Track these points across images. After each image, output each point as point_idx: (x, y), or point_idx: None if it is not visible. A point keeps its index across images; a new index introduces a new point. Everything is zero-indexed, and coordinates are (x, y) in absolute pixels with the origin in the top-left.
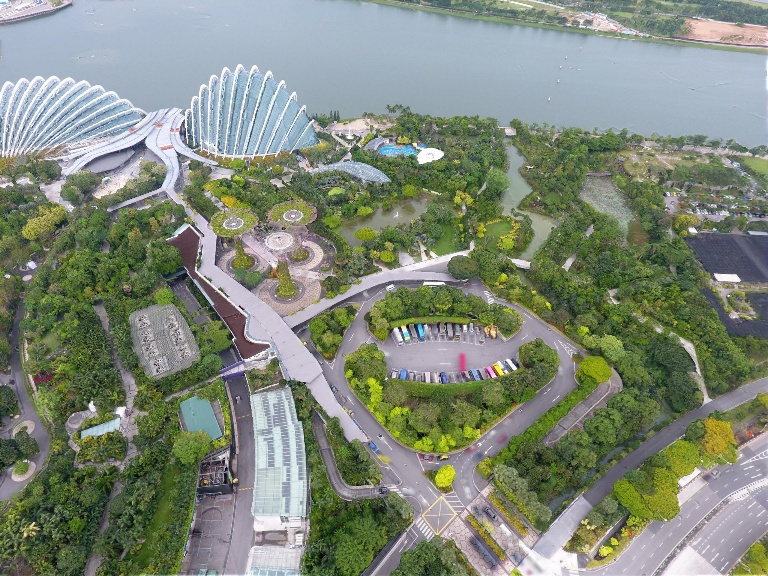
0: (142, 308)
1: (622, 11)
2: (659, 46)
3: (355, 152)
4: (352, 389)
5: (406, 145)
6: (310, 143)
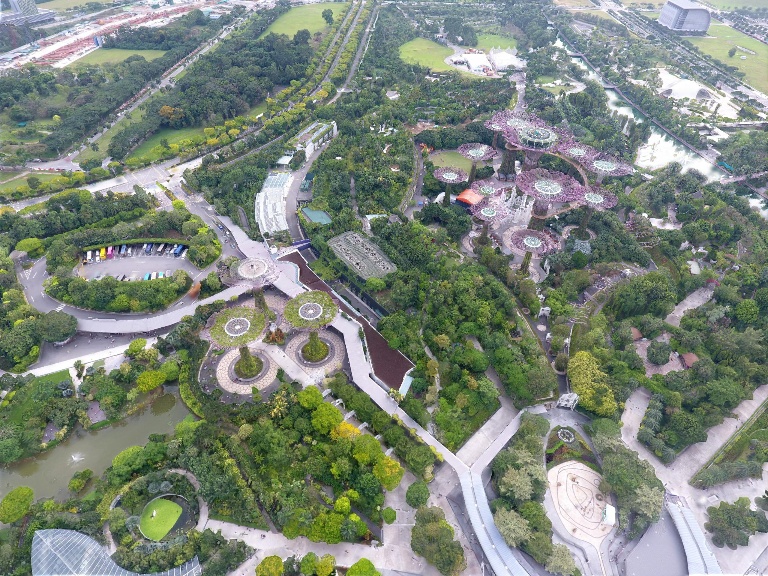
0: None
1: None
2: None
3: None
4: None
5: None
6: None
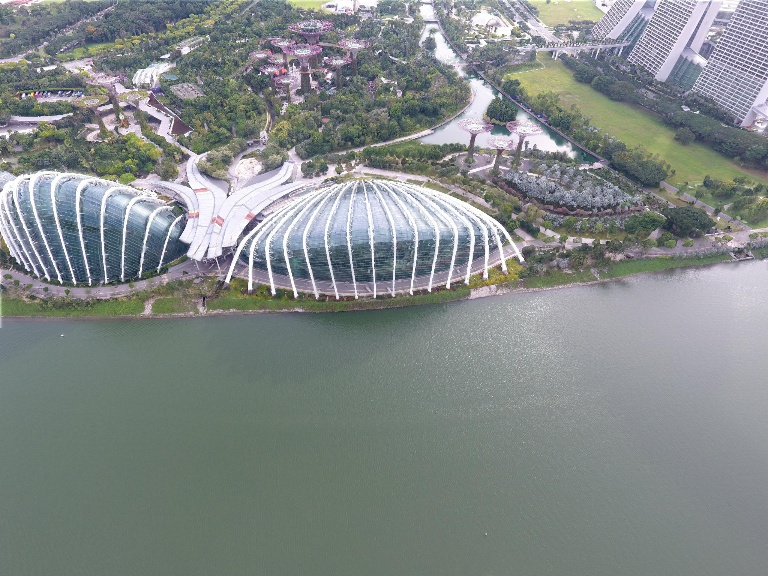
0: None
1: None
2: None
3: None
4: None
5: None
6: None
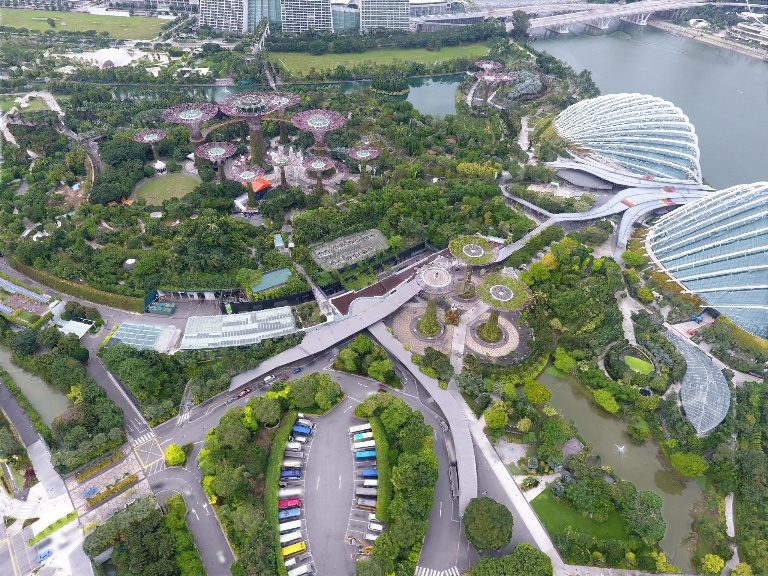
0: (383, 233)
1: None
2: None
3: None
4: None
5: None
6: (749, 325)
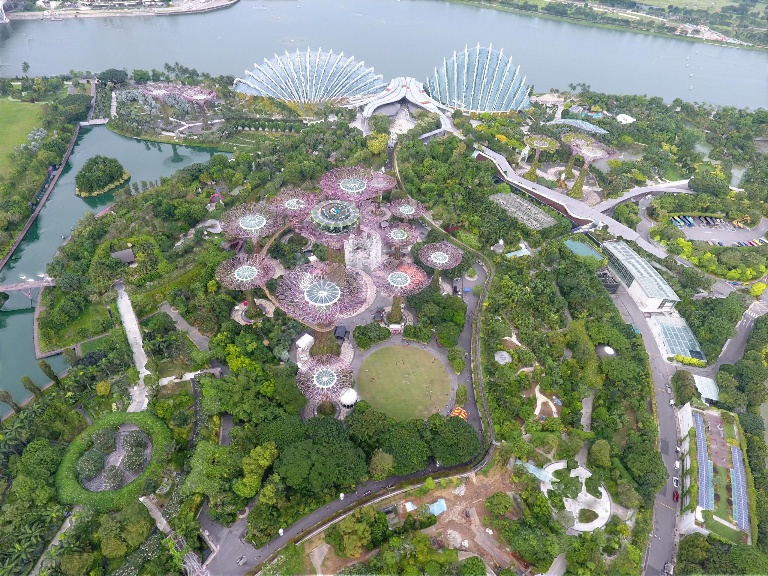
0: (494, 194)
1: (719, 25)
2: (759, 54)
3: (566, 114)
4: (660, 248)
5: (597, 113)
6: (527, 106)
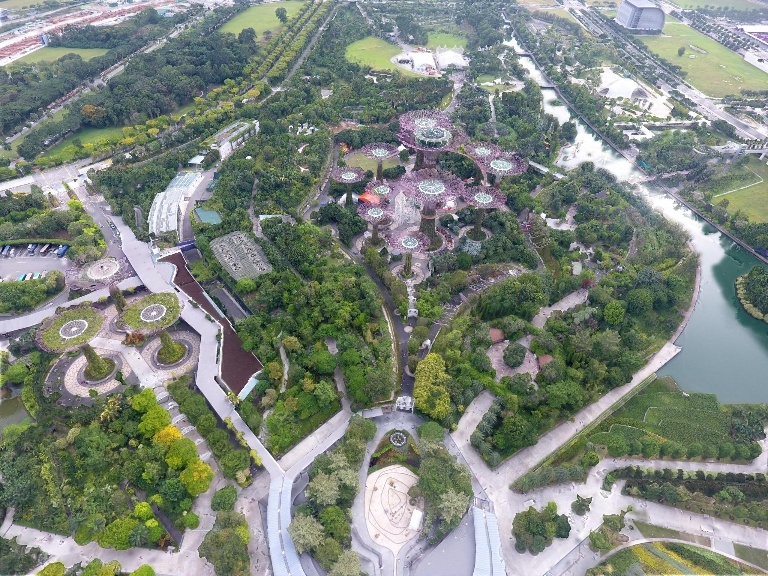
0: None
1: None
2: None
3: None
4: None
5: None
6: None
